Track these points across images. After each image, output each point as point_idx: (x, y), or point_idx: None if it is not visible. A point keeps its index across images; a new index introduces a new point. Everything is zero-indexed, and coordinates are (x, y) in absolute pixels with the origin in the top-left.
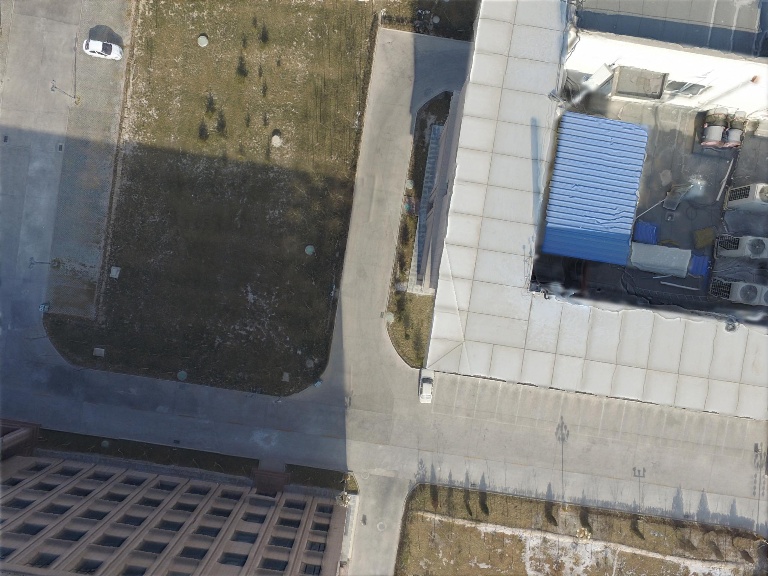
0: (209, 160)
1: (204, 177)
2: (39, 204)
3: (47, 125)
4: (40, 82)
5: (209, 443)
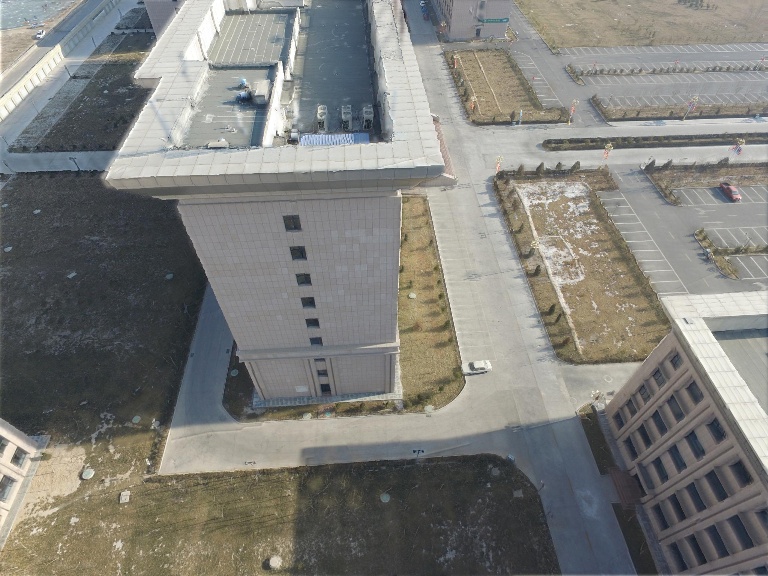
0: None
1: None
2: None
3: None
4: None
5: (625, 568)
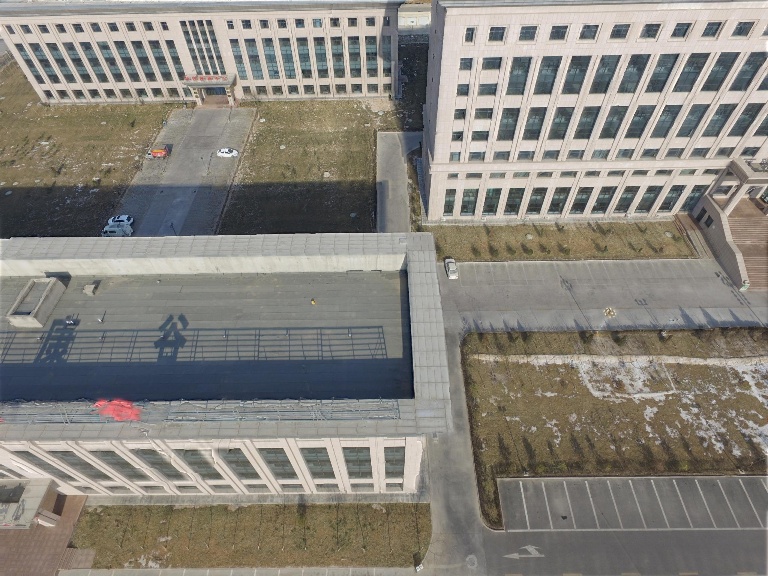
0: (286, 187)
1: (283, 194)
2: (176, 215)
3: (188, 184)
4: (188, 169)
5: None
